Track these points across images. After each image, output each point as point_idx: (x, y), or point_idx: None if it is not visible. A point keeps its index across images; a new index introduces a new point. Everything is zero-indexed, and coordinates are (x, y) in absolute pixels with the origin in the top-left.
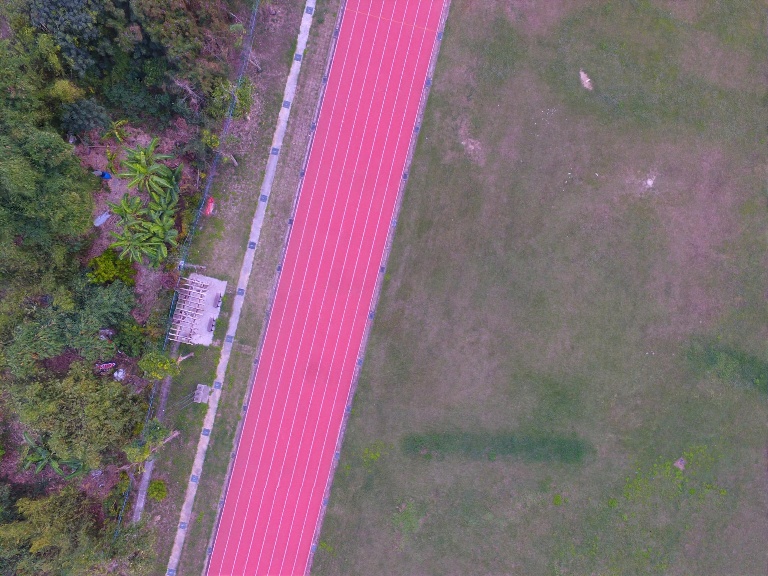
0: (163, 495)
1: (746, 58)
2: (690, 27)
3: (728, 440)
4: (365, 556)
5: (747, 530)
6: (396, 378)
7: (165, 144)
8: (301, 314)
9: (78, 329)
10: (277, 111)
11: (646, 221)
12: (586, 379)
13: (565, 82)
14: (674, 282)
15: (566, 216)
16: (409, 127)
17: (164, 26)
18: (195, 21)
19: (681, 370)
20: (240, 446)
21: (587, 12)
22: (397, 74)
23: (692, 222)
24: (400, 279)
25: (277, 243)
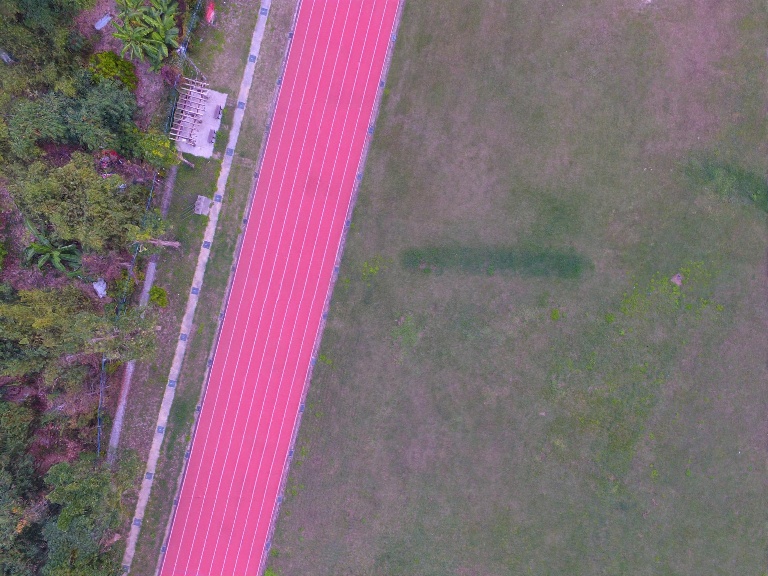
0: (164, 300)
1: None
2: None
3: (725, 256)
4: (364, 369)
5: (743, 346)
6: (395, 192)
7: None
8: (301, 128)
9: (79, 116)
10: None
11: (645, 36)
12: (584, 194)
13: None
14: (672, 98)
15: (565, 31)
16: None
17: None
18: None
19: (679, 186)
20: (240, 259)
21: None
22: None
23: (691, 38)
24: (399, 94)
25: (277, 57)
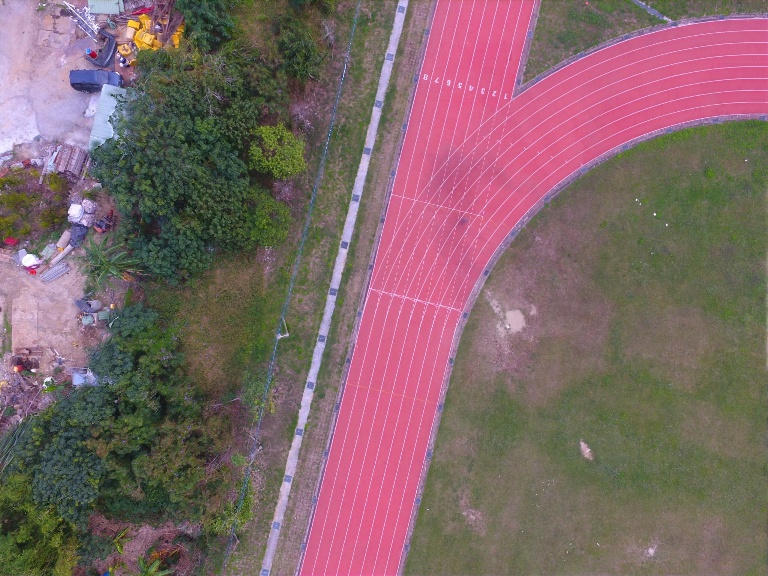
0: None
1: (745, 427)
2: (689, 397)
3: None
4: None
5: None
6: None
7: (167, 528)
8: None
9: None
10: (278, 486)
11: None
12: None
13: (565, 453)
14: None
15: None
16: (410, 499)
17: (166, 475)
18: (197, 443)
19: None
20: None
21: (587, 384)
22: (398, 447)
23: None
24: None
25: None
